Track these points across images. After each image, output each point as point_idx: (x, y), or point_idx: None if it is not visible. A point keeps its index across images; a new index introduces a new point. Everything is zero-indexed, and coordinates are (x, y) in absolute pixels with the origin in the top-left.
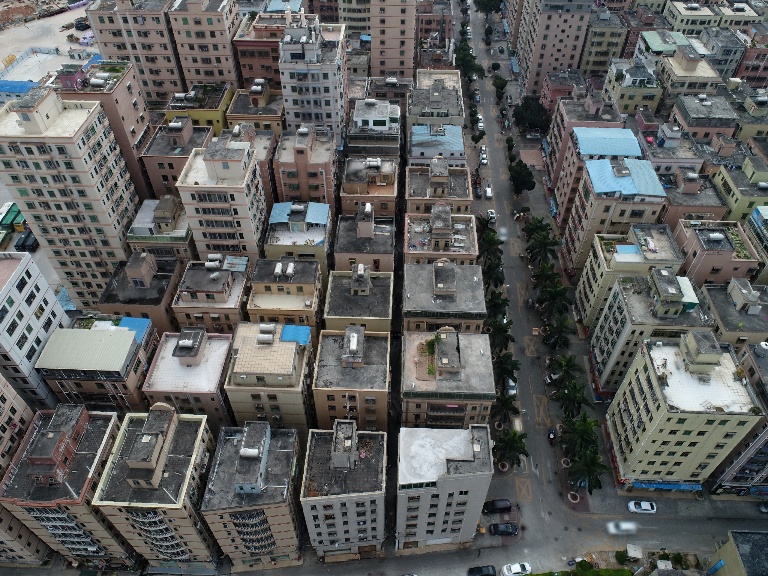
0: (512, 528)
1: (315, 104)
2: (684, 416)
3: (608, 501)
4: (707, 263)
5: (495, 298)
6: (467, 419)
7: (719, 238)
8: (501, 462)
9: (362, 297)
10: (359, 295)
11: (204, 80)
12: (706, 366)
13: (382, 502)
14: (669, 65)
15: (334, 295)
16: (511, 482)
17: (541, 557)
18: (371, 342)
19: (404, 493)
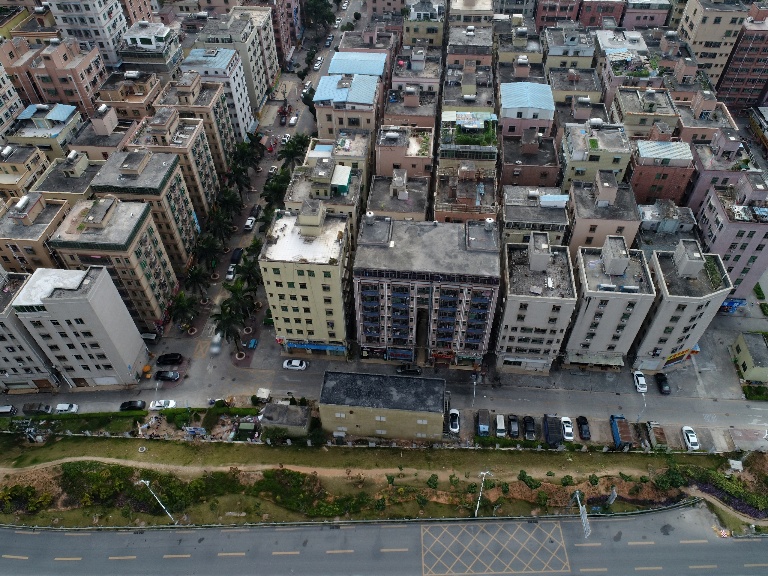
0: (173, 375)
1: (82, 22)
2: (275, 266)
3: (269, 360)
4: (386, 159)
5: (225, 195)
6: (120, 273)
7: (394, 136)
8: (191, 328)
9: (73, 179)
10: (71, 177)
11: (8, 5)
12: (309, 228)
13: (11, 326)
14: (454, 1)
15: (50, 177)
16: (194, 343)
17: (190, 398)
18: (51, 208)
19: (23, 316)
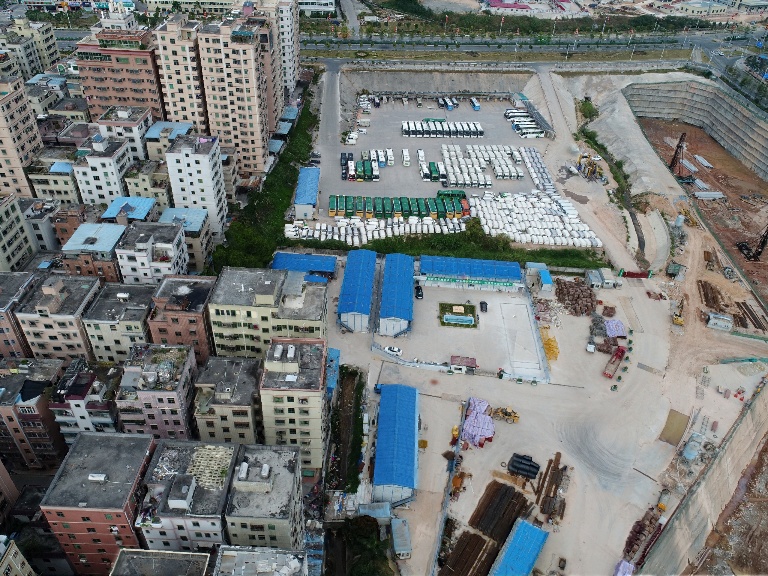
0: None
1: None
2: None
3: None
4: None
5: None
6: None
7: None
8: None
9: None
10: None
11: None
12: None
13: None
14: None
15: None
16: None
17: None
18: None
19: None
